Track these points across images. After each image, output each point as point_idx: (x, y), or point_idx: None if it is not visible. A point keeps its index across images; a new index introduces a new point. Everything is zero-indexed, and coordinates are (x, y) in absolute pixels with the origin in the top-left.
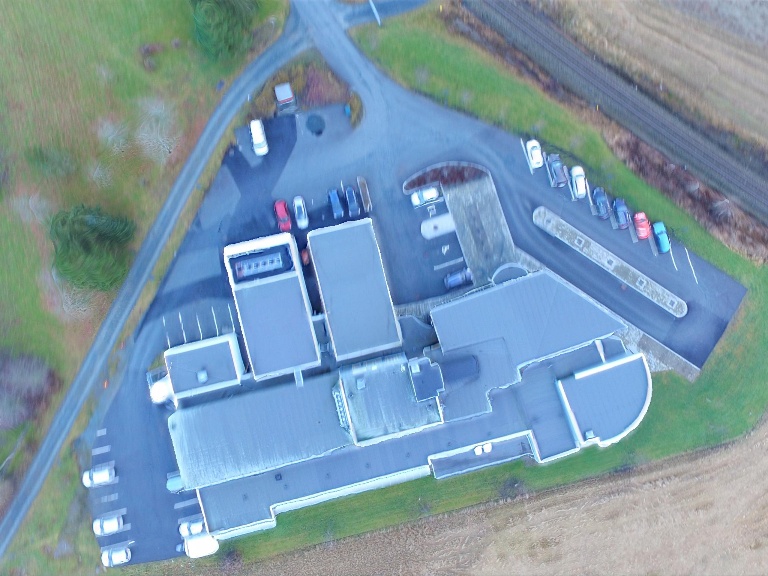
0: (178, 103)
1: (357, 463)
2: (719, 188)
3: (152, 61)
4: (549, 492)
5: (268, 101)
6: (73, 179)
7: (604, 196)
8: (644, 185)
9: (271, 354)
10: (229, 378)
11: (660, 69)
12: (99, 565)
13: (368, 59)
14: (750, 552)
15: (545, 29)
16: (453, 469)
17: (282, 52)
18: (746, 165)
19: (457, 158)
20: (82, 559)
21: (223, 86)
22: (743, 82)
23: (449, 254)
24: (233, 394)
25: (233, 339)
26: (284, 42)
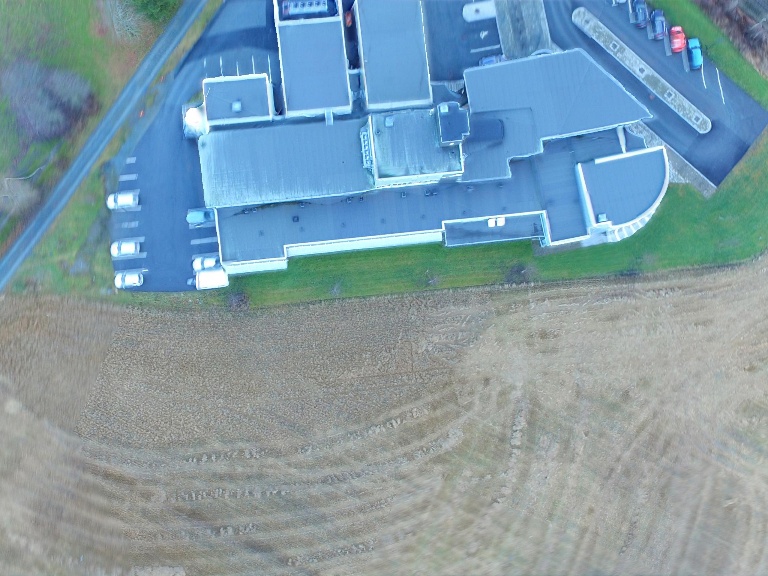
0: None
1: (373, 217)
2: (757, 18)
3: None
4: (554, 284)
5: None
6: None
7: (644, 4)
8: None
9: (305, 94)
10: (262, 113)
11: None
12: (111, 287)
13: None
14: (743, 373)
15: None
16: (465, 239)
17: None
18: None
19: None
20: (96, 279)
21: None
22: None
23: (487, 39)
24: (264, 126)
25: (269, 84)
26: None
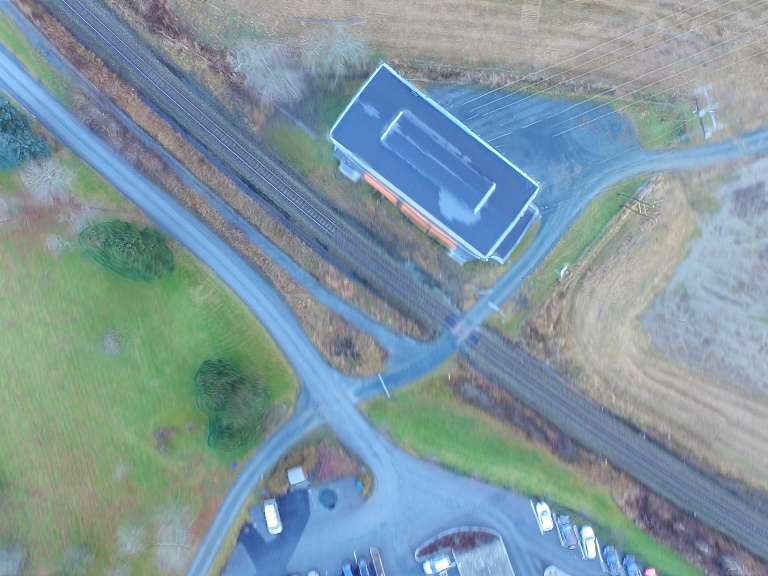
0: (193, 485)
1: None
2: (729, 534)
3: (167, 448)
4: None
5: (281, 482)
6: (93, 573)
7: (614, 555)
8: (654, 544)
9: None
10: None
11: (668, 422)
12: None
13: (378, 431)
14: None
15: (553, 385)
16: None
17: (294, 430)
18: (755, 508)
19: (468, 523)
20: None
21: (237, 466)
22: (751, 432)
23: None
24: None
25: None
26: (295, 420)
